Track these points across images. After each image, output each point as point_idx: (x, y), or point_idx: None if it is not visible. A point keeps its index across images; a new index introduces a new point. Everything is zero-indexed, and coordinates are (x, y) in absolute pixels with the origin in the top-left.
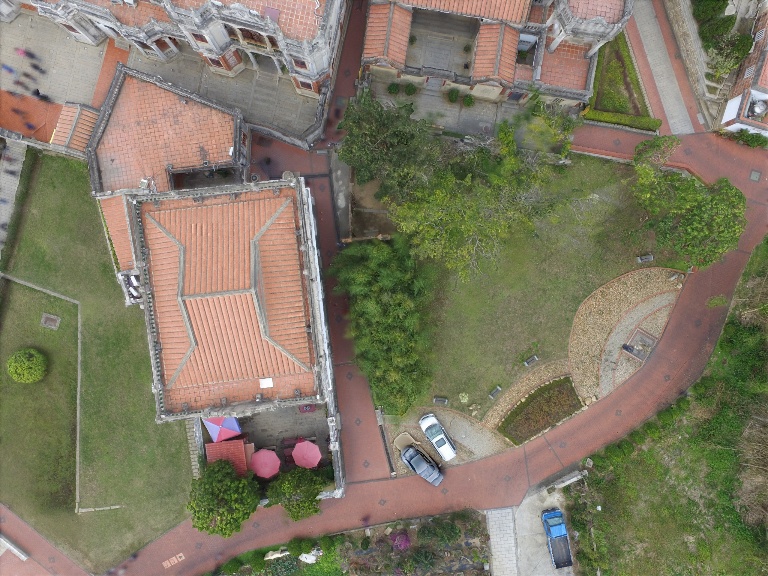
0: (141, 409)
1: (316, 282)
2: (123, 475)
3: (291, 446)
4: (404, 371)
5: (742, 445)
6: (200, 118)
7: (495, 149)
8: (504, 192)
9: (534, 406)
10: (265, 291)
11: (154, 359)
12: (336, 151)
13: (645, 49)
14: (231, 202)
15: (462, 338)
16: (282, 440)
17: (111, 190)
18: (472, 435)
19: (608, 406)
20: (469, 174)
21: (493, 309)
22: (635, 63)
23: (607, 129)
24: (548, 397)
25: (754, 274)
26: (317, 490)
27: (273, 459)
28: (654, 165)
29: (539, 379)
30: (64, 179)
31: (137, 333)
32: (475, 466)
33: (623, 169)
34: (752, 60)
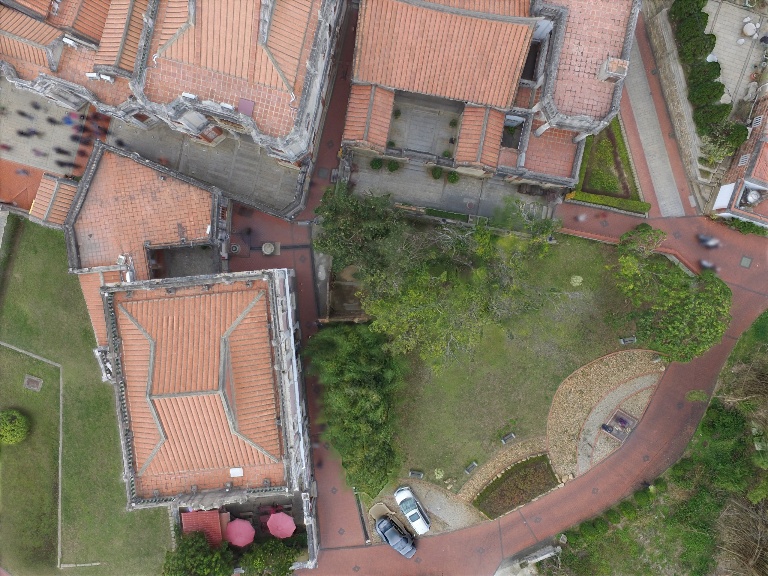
0: (121, 471)
1: (290, 366)
2: (103, 534)
3: (267, 513)
4: (376, 459)
5: (719, 528)
6: (178, 194)
7: (472, 245)
8: (476, 302)
9: (510, 483)
10: (235, 386)
11: (125, 448)
12: (317, 224)
13: (638, 127)
14: (203, 293)
15: (440, 413)
16: (258, 507)
17: (89, 265)
18: (447, 507)
19: (585, 484)
20: (444, 272)
21: (472, 386)
22: (626, 142)
23: (594, 210)
24: (524, 475)
25: (740, 360)
26: (290, 562)
27: (248, 529)
28: (639, 257)
29: (516, 455)
30: (45, 244)
31: None
32: (449, 537)
33: (610, 250)
34: (747, 148)
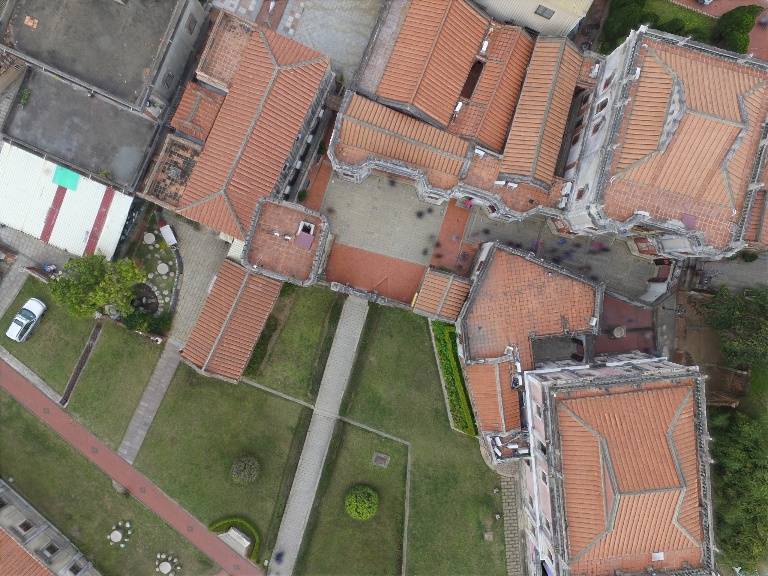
0: (466, 544)
1: None
2: None
3: None
4: None
5: None
6: (562, 288)
7: None
8: None
9: None
10: None
11: None
12: None
13: None
14: (634, 391)
15: None
16: None
17: (478, 356)
18: None
19: None
20: None
21: None
22: None
23: None
24: None
25: None
26: None
27: None
28: None
29: None
30: (401, 329)
31: (465, 474)
32: None
33: None
34: None
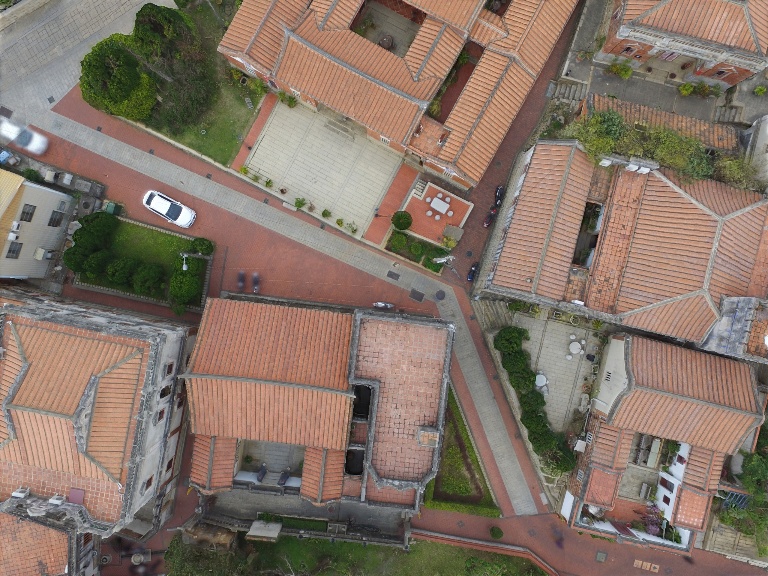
0: None
1: None
2: None
3: None
4: None
5: None
6: (37, 533)
7: None
8: None
9: None
10: None
11: None
12: None
13: (484, 430)
14: None
15: None
16: None
17: None
18: None
19: None
20: None
21: None
22: (474, 447)
23: (450, 511)
24: None
25: None
26: None
27: None
28: None
29: None
30: None
31: None
32: None
33: None
34: (582, 463)
